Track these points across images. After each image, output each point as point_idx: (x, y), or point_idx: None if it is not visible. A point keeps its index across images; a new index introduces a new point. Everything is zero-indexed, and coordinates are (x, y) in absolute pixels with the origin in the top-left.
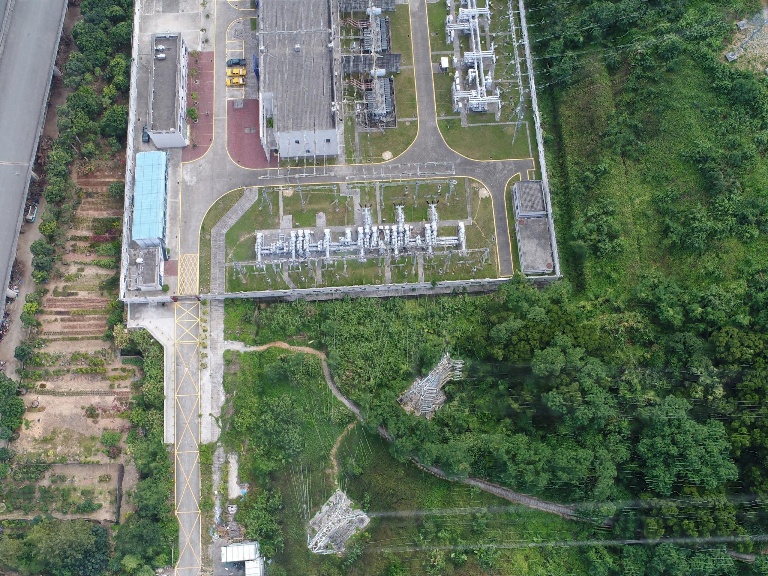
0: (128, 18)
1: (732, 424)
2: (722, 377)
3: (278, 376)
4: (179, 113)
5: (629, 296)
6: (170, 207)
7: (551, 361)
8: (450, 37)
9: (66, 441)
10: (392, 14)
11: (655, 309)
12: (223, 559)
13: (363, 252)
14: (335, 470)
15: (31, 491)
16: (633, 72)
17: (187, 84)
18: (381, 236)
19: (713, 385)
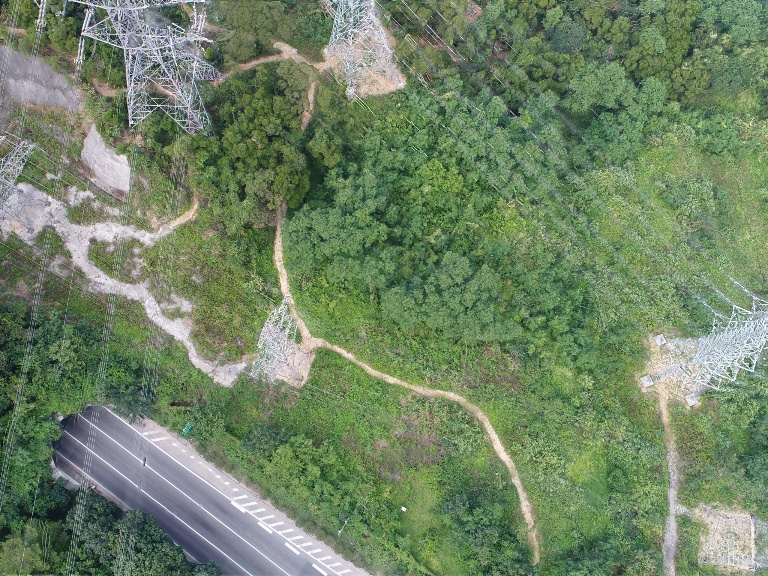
0: None
1: None
2: None
3: None
4: None
5: None
6: None
7: None
8: None
9: None
10: None
11: None
12: None
13: None
14: None
15: None
16: None
17: None
18: None
19: None
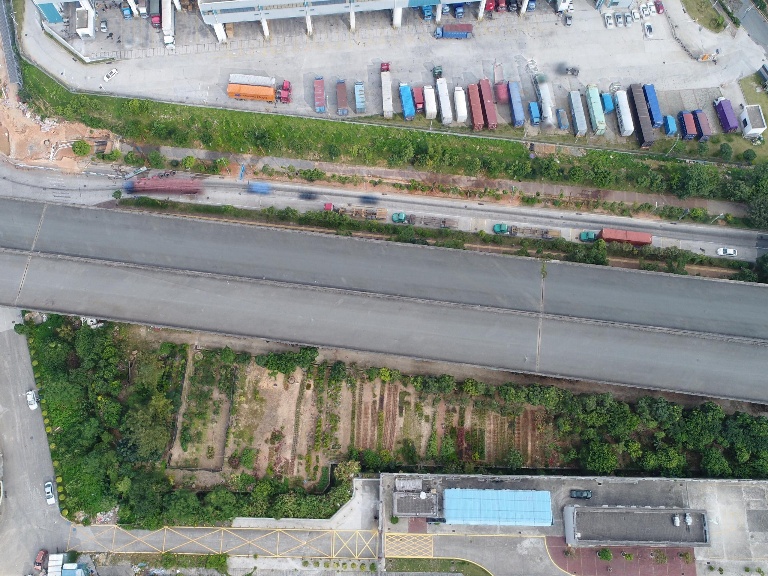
0: (737, 465)
1: None
2: None
3: None
4: None
5: None
6: None
7: None
8: None
9: (252, 412)
10: None
11: None
12: None
13: None
14: None
15: (208, 383)
16: None
17: None
18: None
19: None
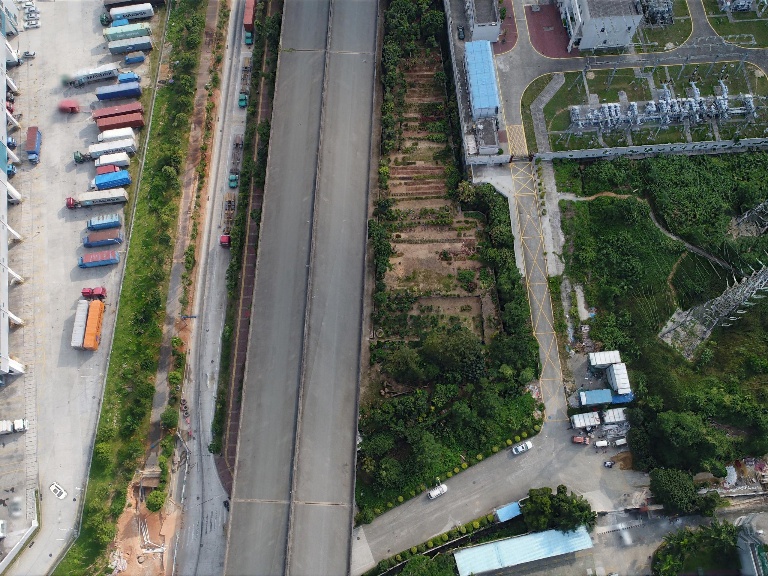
0: None
1: None
2: None
3: (618, 214)
4: None
5: None
6: None
7: None
8: None
9: (426, 279)
10: None
11: None
12: (593, 363)
13: None
14: (673, 293)
15: (406, 318)
16: None
17: None
18: None
19: None
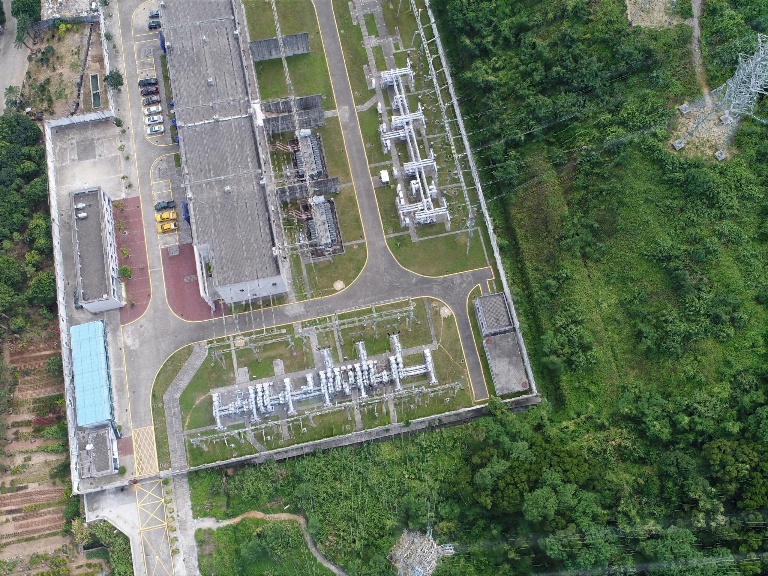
0: (42, 171)
1: (739, 550)
2: (721, 495)
3: (257, 555)
4: (110, 275)
5: (612, 410)
6: (115, 378)
7: (543, 505)
8: (386, 147)
9: None
10: (322, 129)
11: (641, 423)
12: None
13: (328, 397)
14: None
15: None
16: (581, 169)
17: (115, 237)
18: (345, 376)
19: (713, 508)
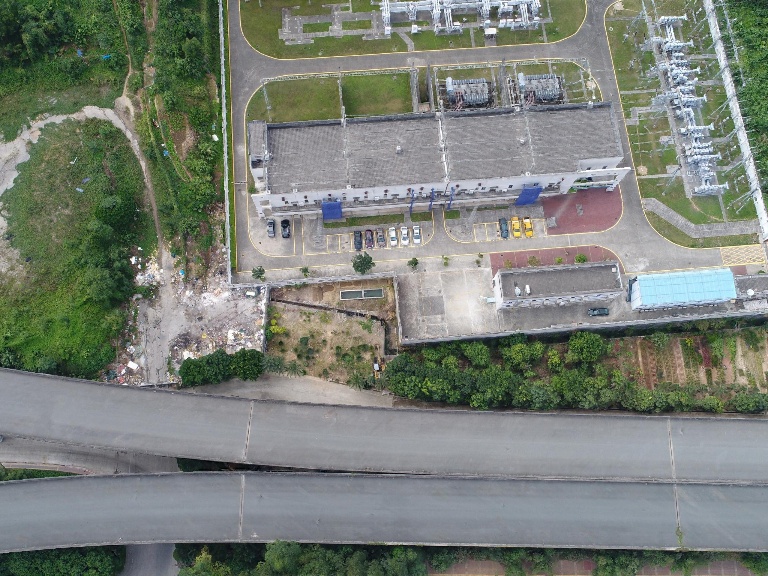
0: None
1: None
2: None
3: None
4: None
5: None
6: None
7: None
8: None
9: None
10: None
11: None
12: None
13: None
14: None
15: None
16: None
17: None
18: None
19: None
